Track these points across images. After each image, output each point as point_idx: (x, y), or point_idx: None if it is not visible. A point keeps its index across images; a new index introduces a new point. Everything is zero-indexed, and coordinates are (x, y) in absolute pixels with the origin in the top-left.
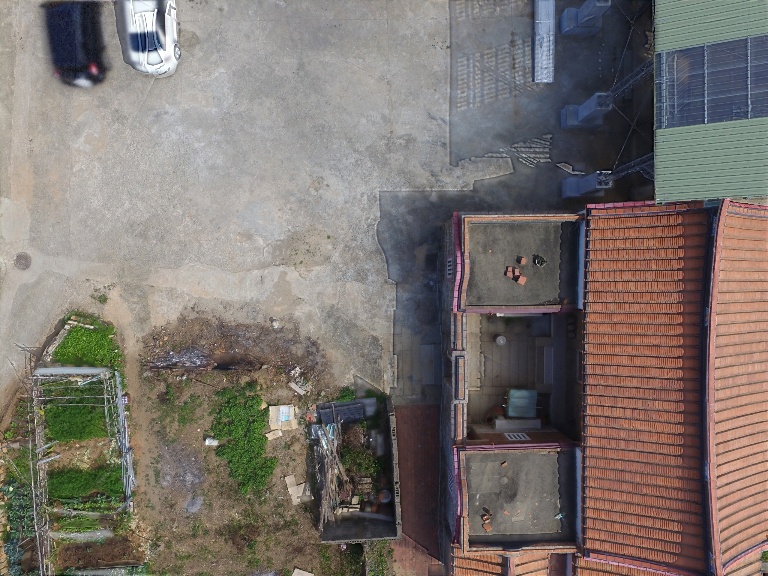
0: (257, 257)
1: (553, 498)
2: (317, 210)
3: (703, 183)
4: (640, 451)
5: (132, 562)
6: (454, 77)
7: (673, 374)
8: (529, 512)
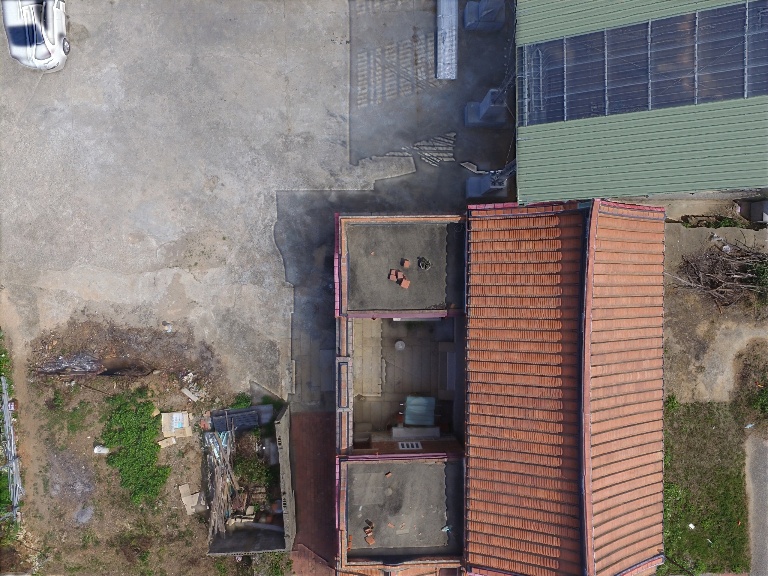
0: (150, 259)
1: (440, 510)
2: (212, 210)
3: (563, 183)
4: (521, 462)
5: (20, 574)
6: (354, 73)
7: (552, 382)
8: (414, 525)
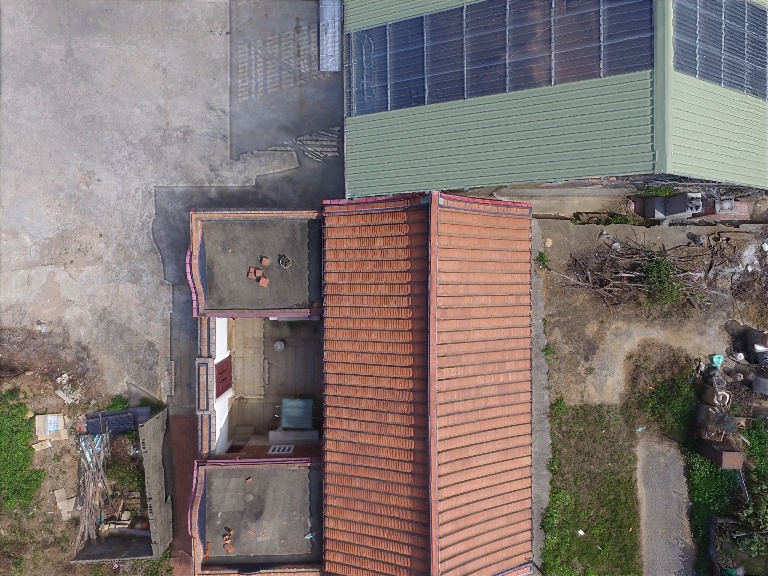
0: (23, 256)
1: (303, 516)
2: (88, 206)
3: (387, 176)
4: (376, 467)
5: None
6: (234, 65)
7: (404, 384)
8: (276, 532)
